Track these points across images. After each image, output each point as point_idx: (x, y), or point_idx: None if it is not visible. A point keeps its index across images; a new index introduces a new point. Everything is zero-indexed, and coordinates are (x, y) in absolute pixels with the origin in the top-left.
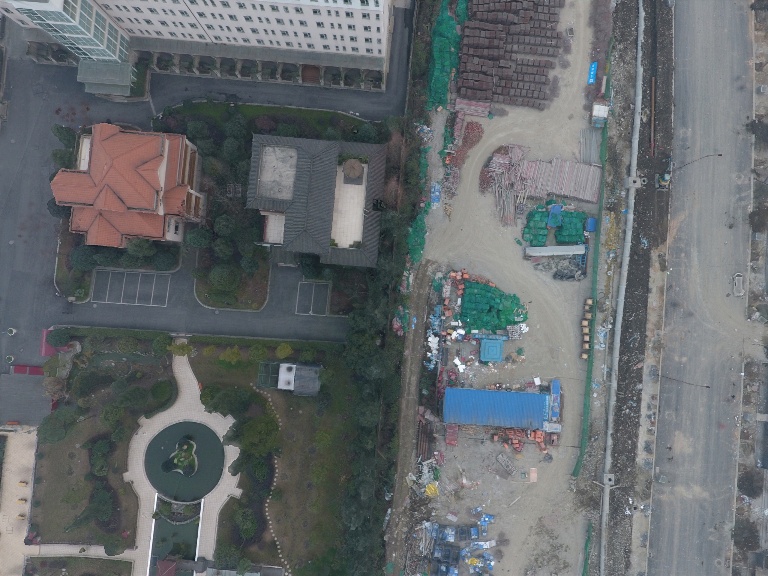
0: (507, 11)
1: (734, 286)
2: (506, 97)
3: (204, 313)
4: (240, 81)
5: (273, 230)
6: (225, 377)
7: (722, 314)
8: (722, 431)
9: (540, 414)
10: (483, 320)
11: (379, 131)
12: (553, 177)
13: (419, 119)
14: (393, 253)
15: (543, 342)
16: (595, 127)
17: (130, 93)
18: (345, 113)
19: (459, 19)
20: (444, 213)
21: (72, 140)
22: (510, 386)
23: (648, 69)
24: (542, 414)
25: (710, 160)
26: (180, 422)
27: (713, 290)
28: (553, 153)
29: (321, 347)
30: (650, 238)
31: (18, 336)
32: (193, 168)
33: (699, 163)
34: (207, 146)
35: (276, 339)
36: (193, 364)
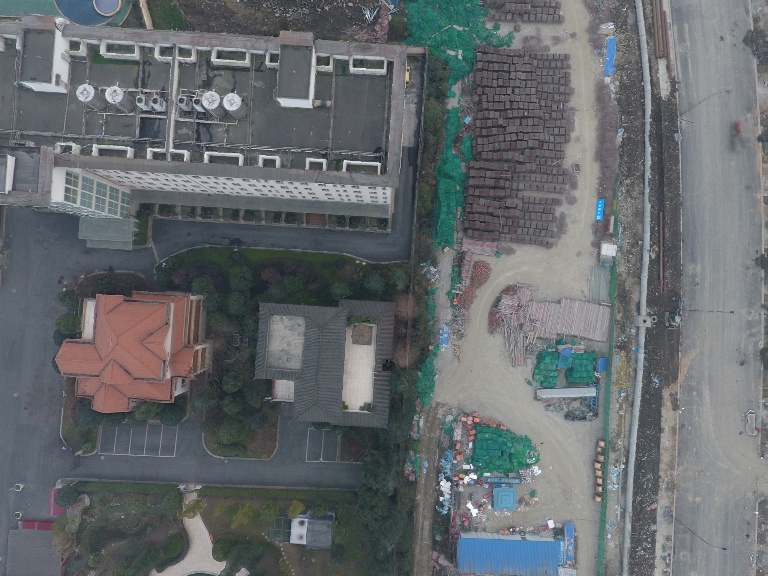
0: (512, 149)
1: (746, 424)
2: (513, 236)
3: (213, 463)
4: (243, 225)
5: (281, 385)
6: (236, 527)
7: (735, 452)
8: (737, 571)
9: (555, 562)
10: (495, 464)
11: (386, 283)
12: (562, 318)
13: (425, 259)
14: (403, 402)
15: (556, 483)
16: (604, 266)
17: (132, 247)
18: (351, 255)
19: (464, 156)
20: (453, 355)
21: (75, 304)
22: (524, 529)
23: (656, 204)
24: (557, 562)
25: (720, 296)
26: (192, 574)
27: (725, 428)
28: (562, 291)
29: (333, 498)
30: (661, 377)
31: (25, 490)
32: (198, 317)
33: (709, 299)
34: (212, 304)
35: (287, 487)
36: (203, 515)
